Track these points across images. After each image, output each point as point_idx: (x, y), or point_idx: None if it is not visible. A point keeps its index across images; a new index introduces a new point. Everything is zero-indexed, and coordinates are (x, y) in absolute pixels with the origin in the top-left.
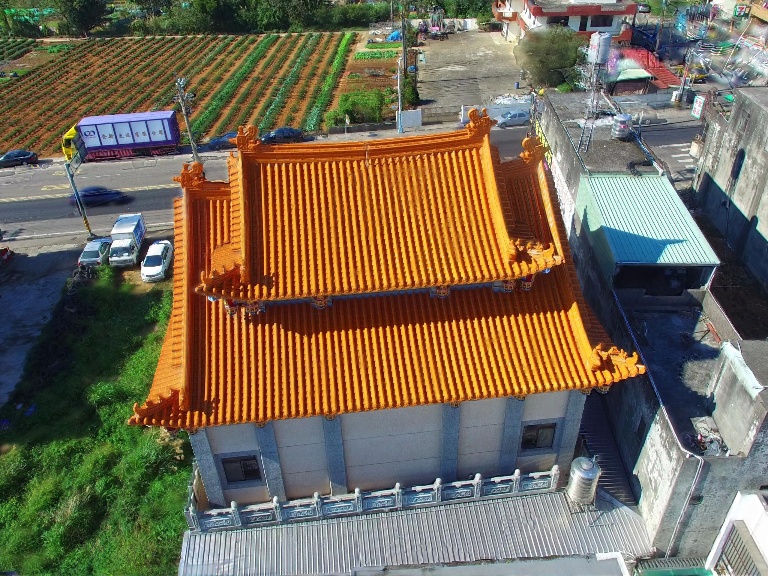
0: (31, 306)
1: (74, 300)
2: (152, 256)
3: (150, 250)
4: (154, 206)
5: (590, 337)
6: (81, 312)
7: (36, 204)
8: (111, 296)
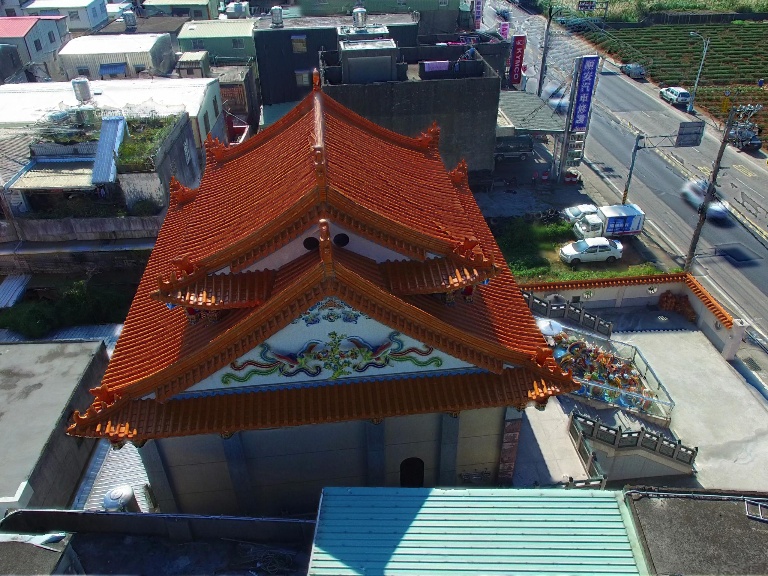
0: (506, 208)
1: (505, 219)
2: (586, 242)
3: (594, 238)
4: (706, 231)
5: (157, 410)
6: (494, 228)
7: (668, 171)
8: (524, 238)
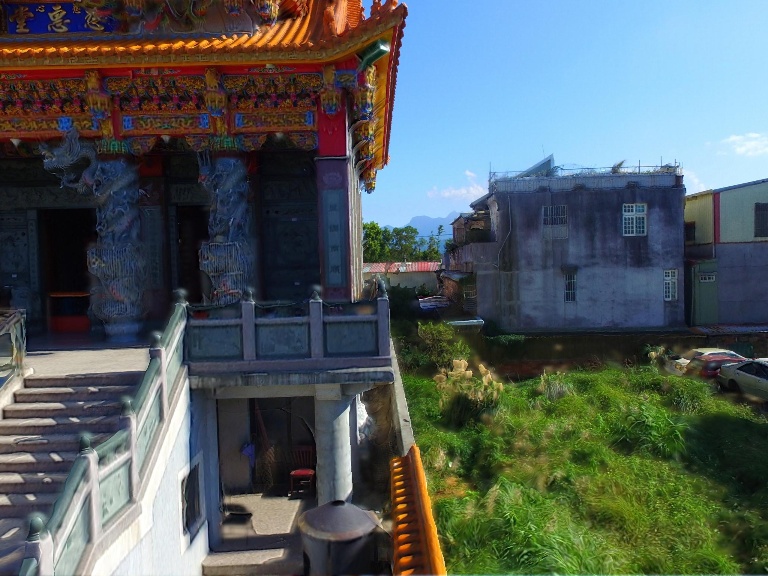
0: None
1: None
2: None
3: None
4: None
5: None
6: None
7: None
8: None
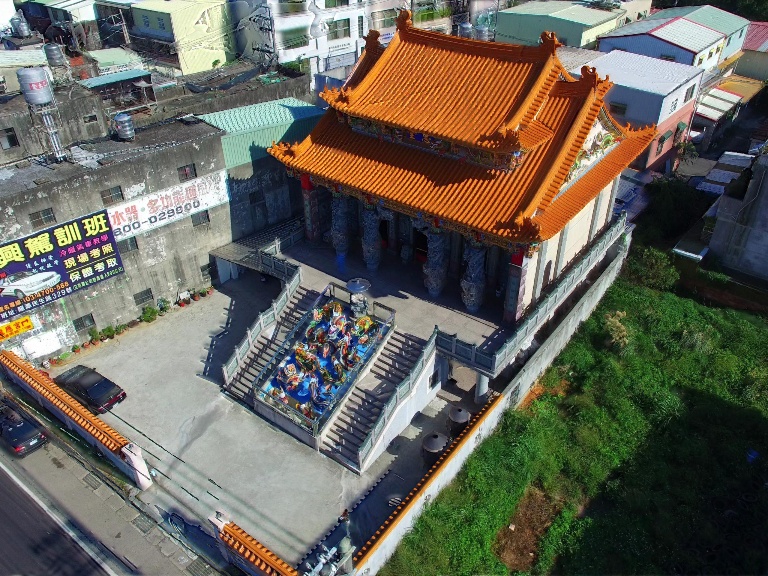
0: None
1: None
2: None
3: None
4: None
5: None
6: None
7: None
8: None
